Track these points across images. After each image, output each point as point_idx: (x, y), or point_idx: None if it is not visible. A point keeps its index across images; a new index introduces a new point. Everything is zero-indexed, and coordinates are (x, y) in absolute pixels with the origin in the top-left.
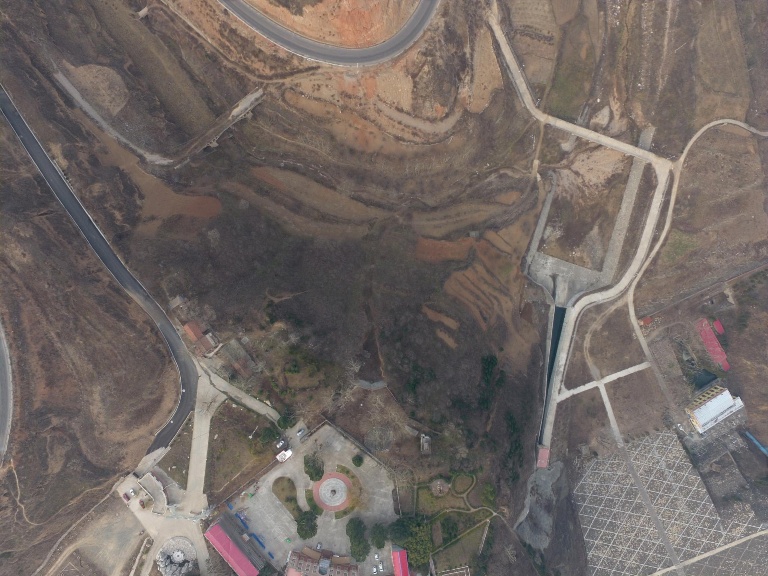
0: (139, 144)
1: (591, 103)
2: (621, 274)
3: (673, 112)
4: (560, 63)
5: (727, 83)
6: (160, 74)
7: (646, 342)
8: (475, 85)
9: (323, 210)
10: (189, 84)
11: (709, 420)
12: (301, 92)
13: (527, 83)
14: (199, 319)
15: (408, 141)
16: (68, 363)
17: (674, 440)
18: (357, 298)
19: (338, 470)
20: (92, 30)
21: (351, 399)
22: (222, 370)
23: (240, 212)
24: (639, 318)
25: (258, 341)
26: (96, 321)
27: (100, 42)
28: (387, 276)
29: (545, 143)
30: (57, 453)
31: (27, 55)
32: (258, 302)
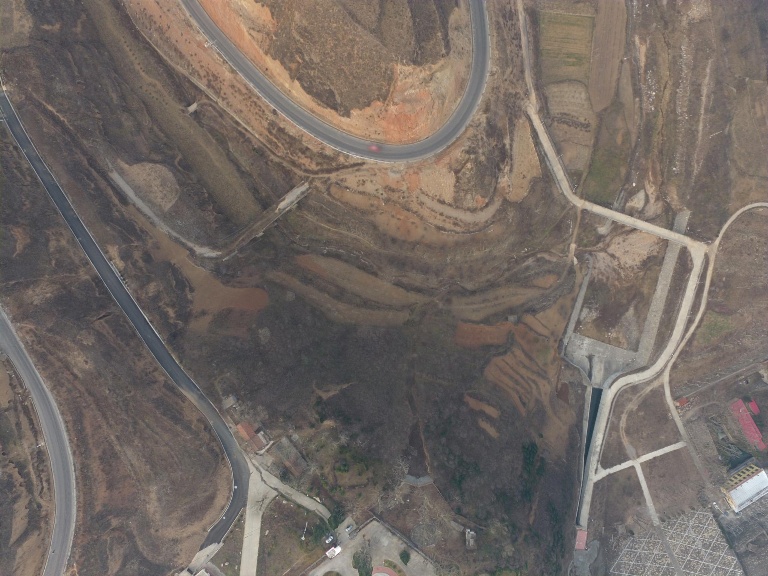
0: (189, 238)
1: (627, 187)
2: (657, 355)
3: (708, 196)
4: (596, 149)
5: (762, 167)
6: (208, 166)
7: (682, 422)
8: (514, 174)
9: (365, 296)
10: (236, 176)
11: (745, 500)
12: (346, 186)
13: (564, 170)
14: (251, 418)
15: (449, 231)
16: (127, 465)
17: (710, 519)
18: (401, 388)
19: (385, 565)
20: (144, 126)
21: (401, 501)
22: (273, 467)
23: (287, 304)
24: (675, 399)
25: (308, 438)
26: (154, 424)
27: (151, 138)
28: (429, 364)
29: (582, 228)
30: (116, 553)
31: (84, 156)
32: (306, 397)
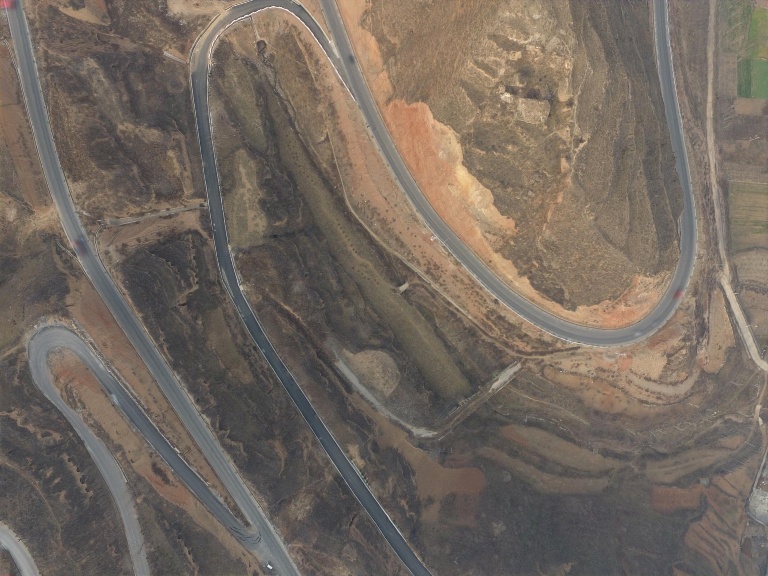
0: (408, 420)
1: None
2: None
3: None
4: None
5: None
6: (417, 343)
7: None
8: (710, 346)
9: (564, 463)
10: (444, 352)
11: None
12: (559, 368)
13: (753, 336)
14: None
15: (651, 403)
16: None
17: None
18: (614, 564)
19: None
20: (360, 309)
21: None
22: None
23: None
24: None
25: None
26: None
27: (366, 320)
28: (636, 536)
29: None
30: None
31: (314, 350)
32: None
